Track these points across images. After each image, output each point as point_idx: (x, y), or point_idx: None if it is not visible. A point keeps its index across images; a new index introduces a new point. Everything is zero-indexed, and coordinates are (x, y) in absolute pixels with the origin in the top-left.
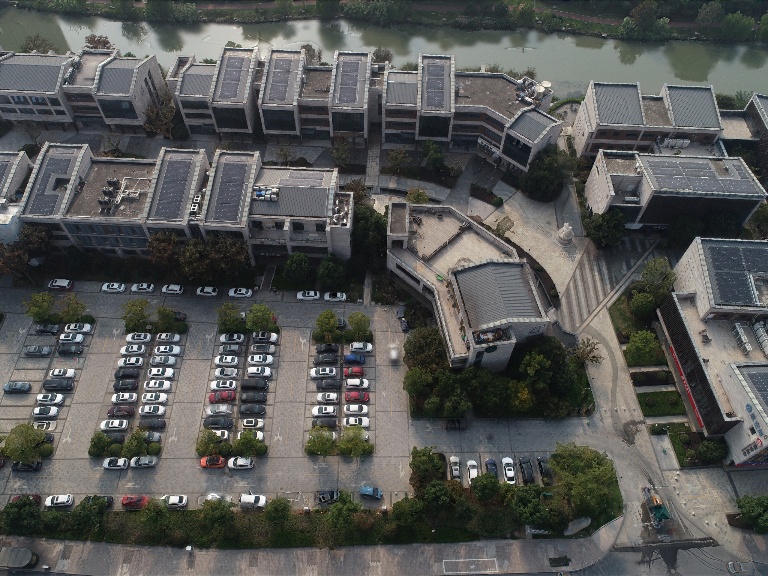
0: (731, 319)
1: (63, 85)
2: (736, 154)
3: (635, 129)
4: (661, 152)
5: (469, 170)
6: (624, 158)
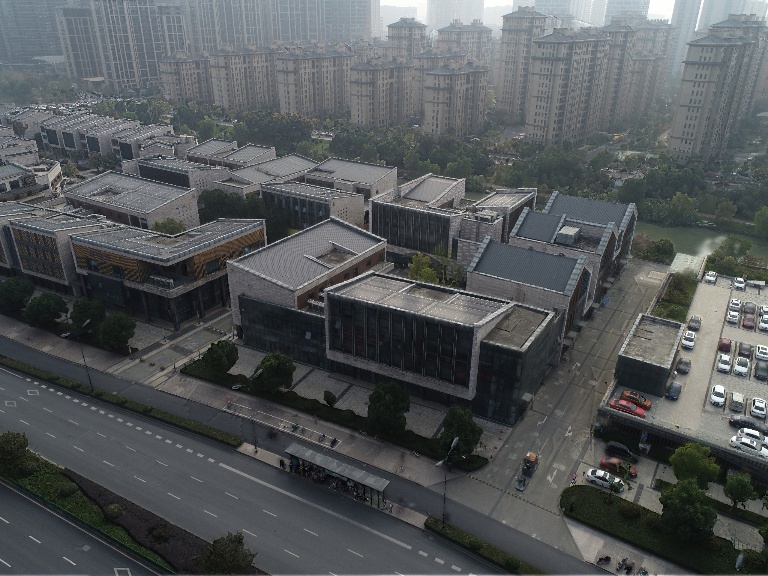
0: (76, 206)
1: (7, 114)
2: None
3: (204, 157)
4: None
5: None
6: None
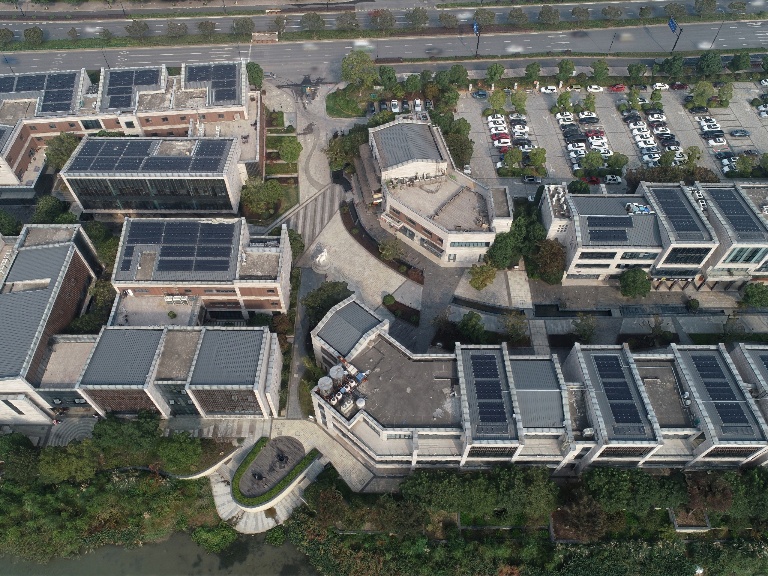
0: None
1: None
2: (96, 321)
3: None
4: (190, 321)
5: (421, 349)
6: (252, 277)
